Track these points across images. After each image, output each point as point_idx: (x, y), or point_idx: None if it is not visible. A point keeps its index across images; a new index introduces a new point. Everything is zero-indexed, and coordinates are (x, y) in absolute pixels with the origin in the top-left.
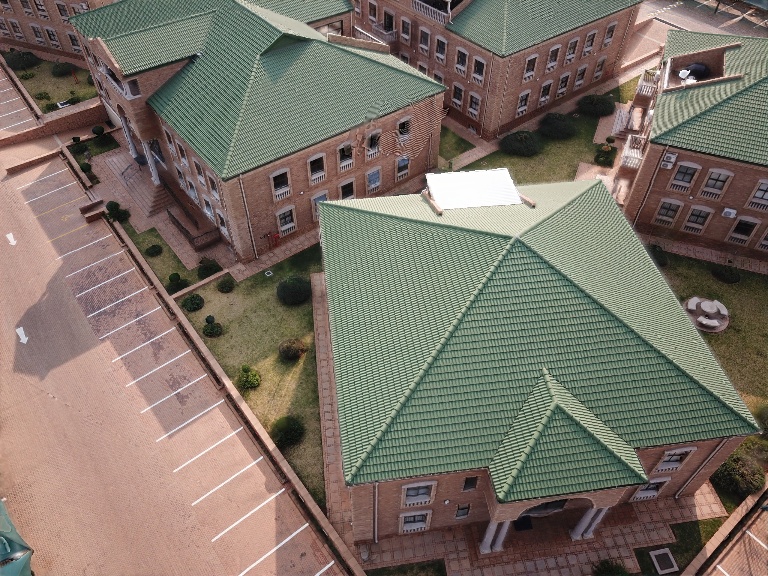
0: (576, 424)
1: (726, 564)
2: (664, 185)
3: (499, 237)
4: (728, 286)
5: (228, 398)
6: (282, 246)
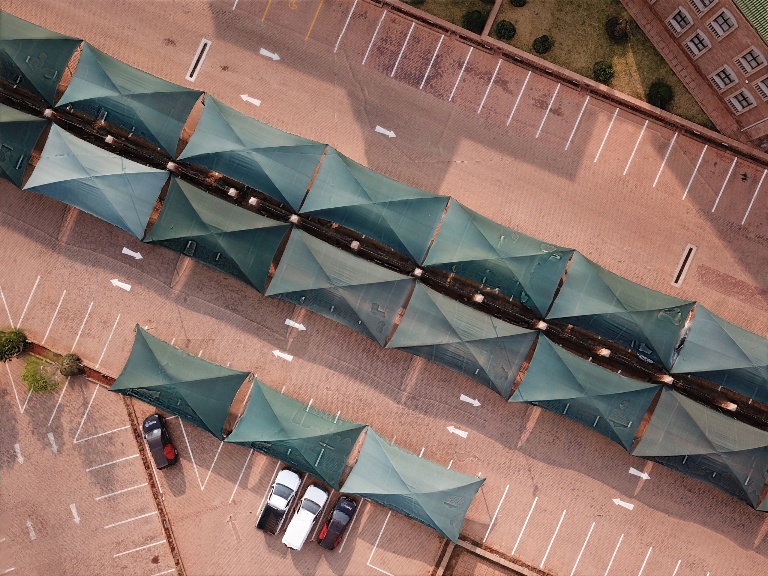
0: None
1: None
2: None
3: None
4: None
5: (593, 93)
6: None
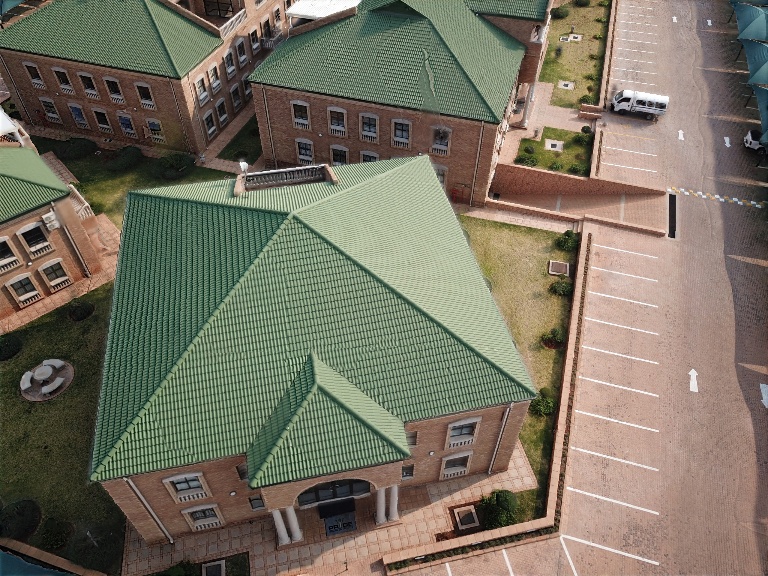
0: None
1: None
2: None
3: None
4: None
5: None
6: (53, 129)
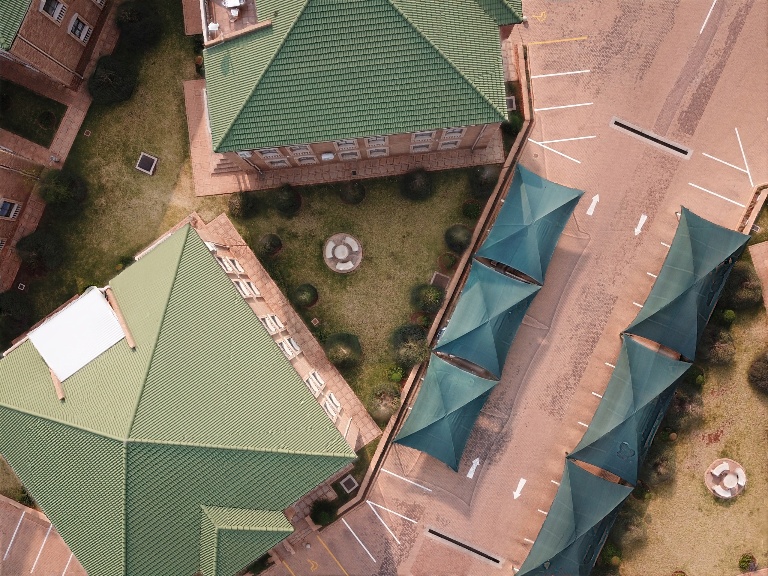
0: (236, 531)
1: (386, 465)
2: (258, 157)
3: (114, 440)
4: (356, 208)
5: None
6: None
